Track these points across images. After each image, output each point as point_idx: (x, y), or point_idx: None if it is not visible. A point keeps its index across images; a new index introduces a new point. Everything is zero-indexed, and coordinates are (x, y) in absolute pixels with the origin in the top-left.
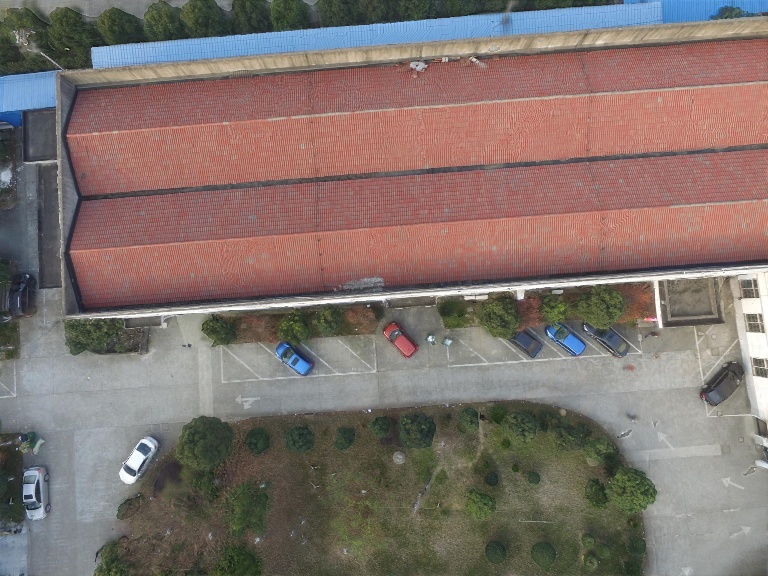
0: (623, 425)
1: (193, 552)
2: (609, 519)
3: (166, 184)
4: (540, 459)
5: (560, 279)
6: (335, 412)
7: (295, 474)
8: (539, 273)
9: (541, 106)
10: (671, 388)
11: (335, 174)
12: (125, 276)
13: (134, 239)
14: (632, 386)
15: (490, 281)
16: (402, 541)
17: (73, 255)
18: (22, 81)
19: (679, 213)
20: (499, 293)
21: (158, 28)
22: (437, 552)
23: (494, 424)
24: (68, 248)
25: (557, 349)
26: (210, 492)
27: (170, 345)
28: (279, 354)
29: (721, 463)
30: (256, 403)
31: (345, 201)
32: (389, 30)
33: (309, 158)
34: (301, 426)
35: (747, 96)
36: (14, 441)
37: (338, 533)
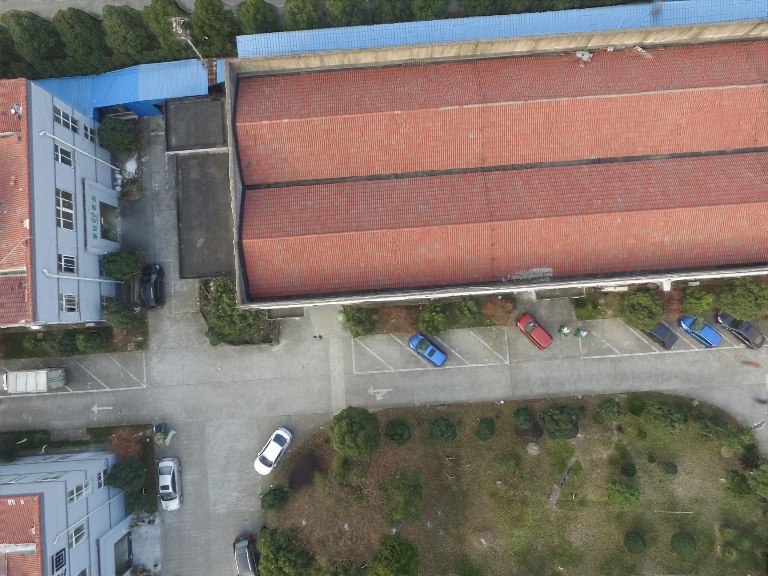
0: (756, 416)
1: (329, 543)
2: (744, 510)
3: (331, 173)
4: (675, 450)
5: (738, 269)
6: (467, 403)
7: (430, 465)
8: (708, 263)
9: (710, 96)
10: None
11: (501, 164)
12: (295, 266)
13: (306, 228)
14: (765, 378)
15: (658, 271)
16: (538, 532)
17: (245, 244)
18: (157, 70)
19: None
20: (640, 284)
21: (302, 17)
22: (573, 542)
23: (628, 415)
24: (241, 237)
25: (690, 341)
26: (345, 483)
27: (301, 336)
28: (414, 345)
29: None
30: (388, 394)
31: (515, 191)
32: (538, 19)
33: (477, 148)
34: (435, 417)
35: None
36: (145, 432)
37: (474, 524)
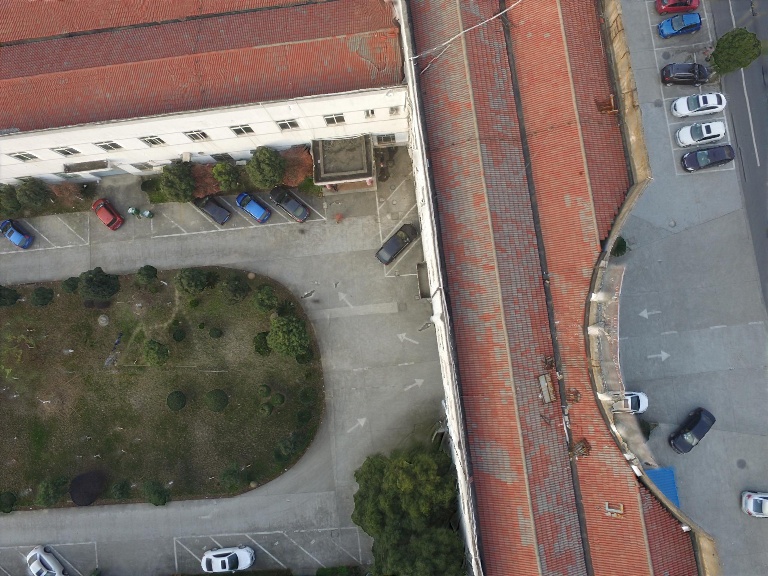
0: (307, 286)
1: None
2: (289, 373)
3: None
4: (228, 318)
5: (152, 115)
6: (53, 282)
7: None
8: None
9: None
10: (352, 251)
11: None
12: None
13: None
14: (316, 250)
15: None
16: (102, 395)
17: None
18: None
19: (264, 53)
20: (178, 161)
21: None
22: (133, 405)
23: None
24: None
25: (249, 218)
26: None
27: None
28: (1, 229)
29: (397, 320)
30: None
31: None
32: None
33: None
34: None
35: None
36: None
37: (47, 389)
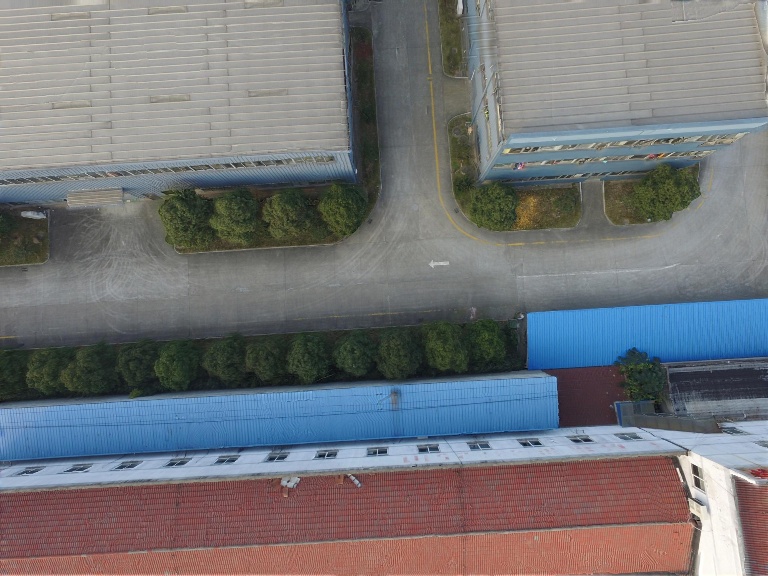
0: None
1: None
2: None
3: None
4: None
5: None
6: None
7: None
8: None
9: None
10: None
11: None
12: None
13: None
14: None
15: None
16: None
17: None
18: None
19: None
20: None
21: (39, 386)
22: None
23: None
24: None
25: None
26: None
27: None
28: None
29: None
30: None
31: None
32: (274, 400)
33: None
34: None
35: (628, 535)
36: None
37: None
